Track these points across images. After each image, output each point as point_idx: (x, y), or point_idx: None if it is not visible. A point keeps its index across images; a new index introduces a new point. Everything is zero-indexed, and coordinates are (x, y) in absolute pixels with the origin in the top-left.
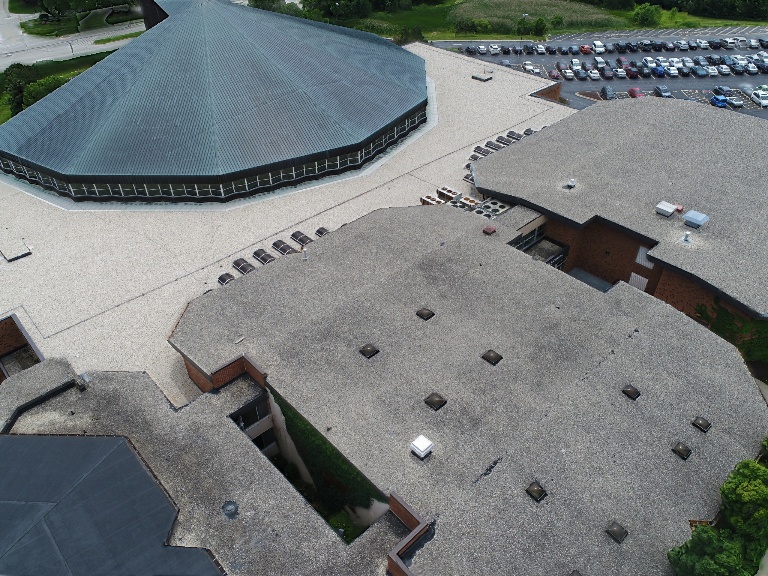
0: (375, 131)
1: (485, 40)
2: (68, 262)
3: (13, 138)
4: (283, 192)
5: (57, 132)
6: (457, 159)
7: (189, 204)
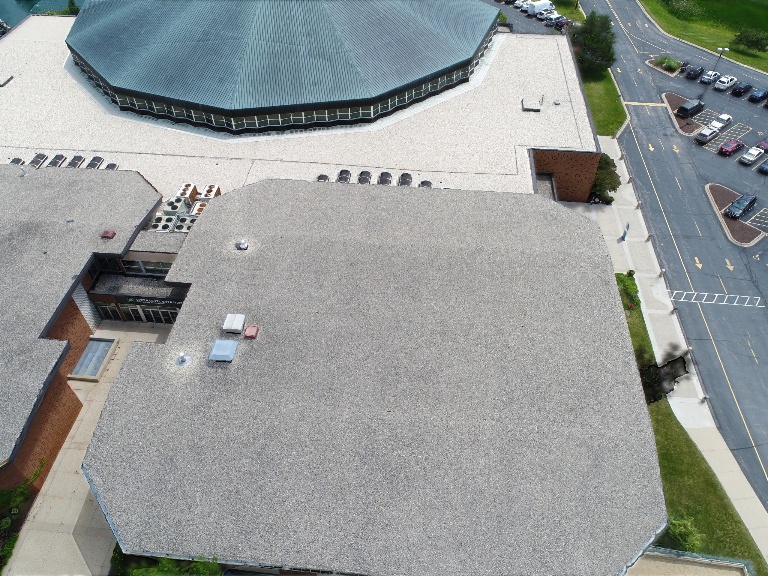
0: (261, 106)
1: (749, 66)
2: (1, 102)
3: (93, 1)
4: (160, 123)
5: (103, 7)
6: (311, 171)
7: (107, 99)
